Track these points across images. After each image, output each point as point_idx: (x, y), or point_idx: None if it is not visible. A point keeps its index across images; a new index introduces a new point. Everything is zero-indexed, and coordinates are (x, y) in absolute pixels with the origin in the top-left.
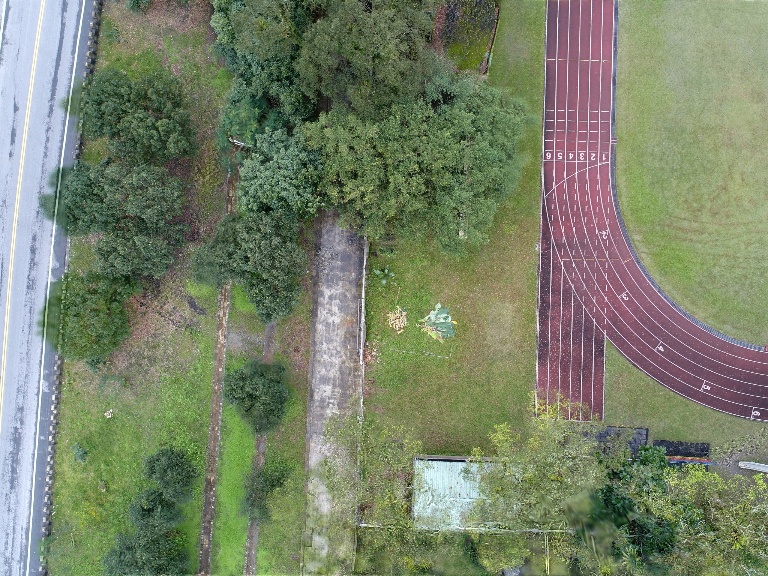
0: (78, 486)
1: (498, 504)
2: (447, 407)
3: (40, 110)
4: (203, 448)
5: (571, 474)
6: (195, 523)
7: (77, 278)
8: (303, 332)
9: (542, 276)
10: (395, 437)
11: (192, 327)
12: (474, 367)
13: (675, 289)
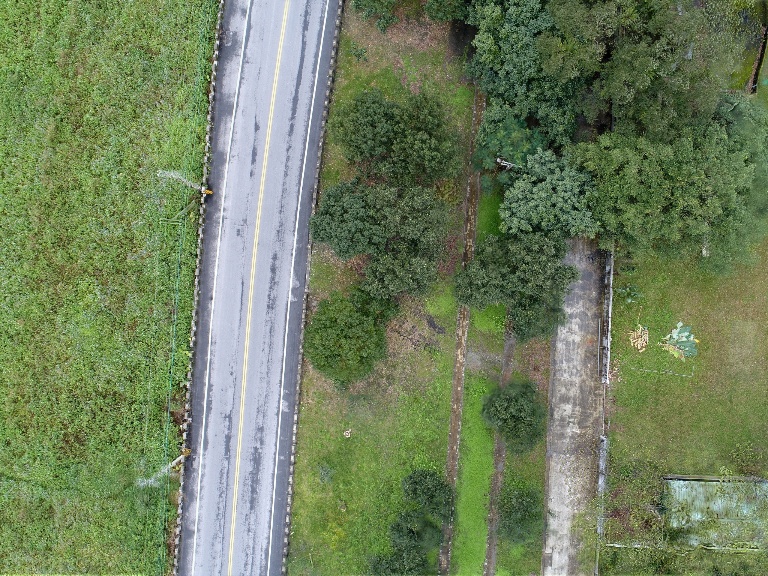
0: (317, 506)
1: (756, 524)
2: (689, 426)
3: (281, 129)
4: (442, 467)
5: None
6: (434, 543)
7: (316, 297)
8: (543, 351)
9: None
10: (636, 456)
11: (431, 346)
12: (716, 386)
13: None
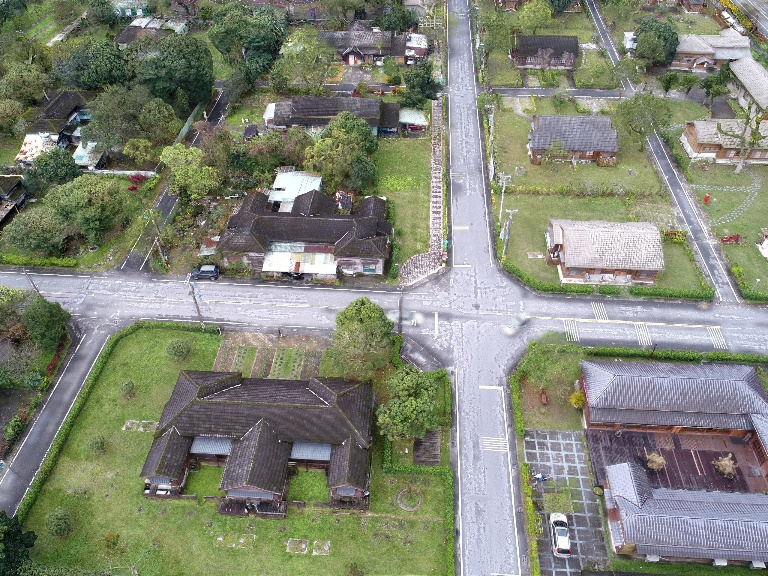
0: None
1: (141, 2)
2: None
3: None
4: None
5: None
6: None
7: None
8: None
9: None
10: None
11: None
12: None
13: None
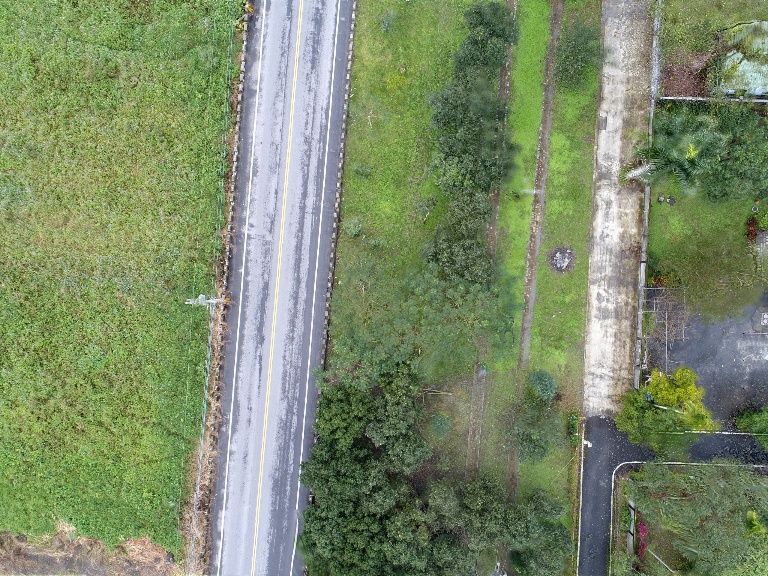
0: (376, 69)
1: None
2: None
3: None
4: (499, 33)
5: None
6: (490, 107)
7: None
8: None
9: None
10: (690, 20)
11: None
12: None
13: None
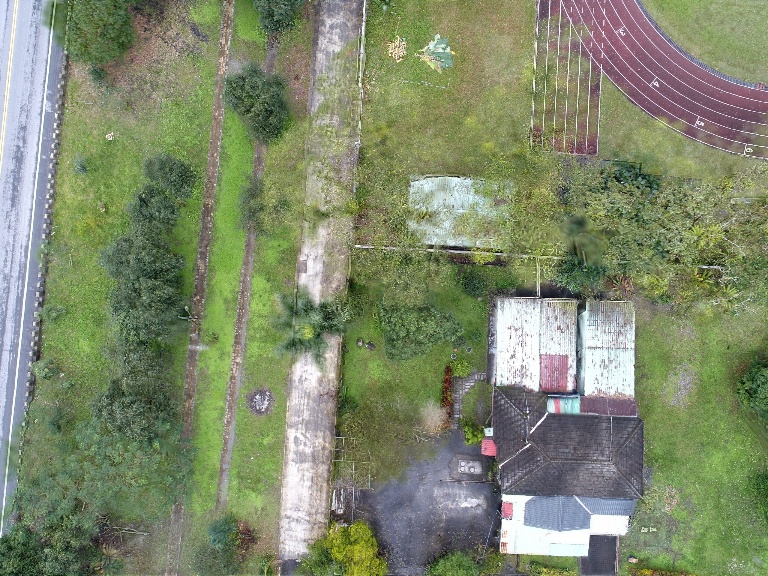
0: (78, 207)
1: (491, 216)
2: (443, 137)
3: None
4: (202, 174)
5: (564, 205)
6: (192, 248)
7: (83, 1)
8: (303, 61)
9: (541, 9)
10: (391, 166)
11: (194, 53)
12: (471, 98)
13: (672, 25)
